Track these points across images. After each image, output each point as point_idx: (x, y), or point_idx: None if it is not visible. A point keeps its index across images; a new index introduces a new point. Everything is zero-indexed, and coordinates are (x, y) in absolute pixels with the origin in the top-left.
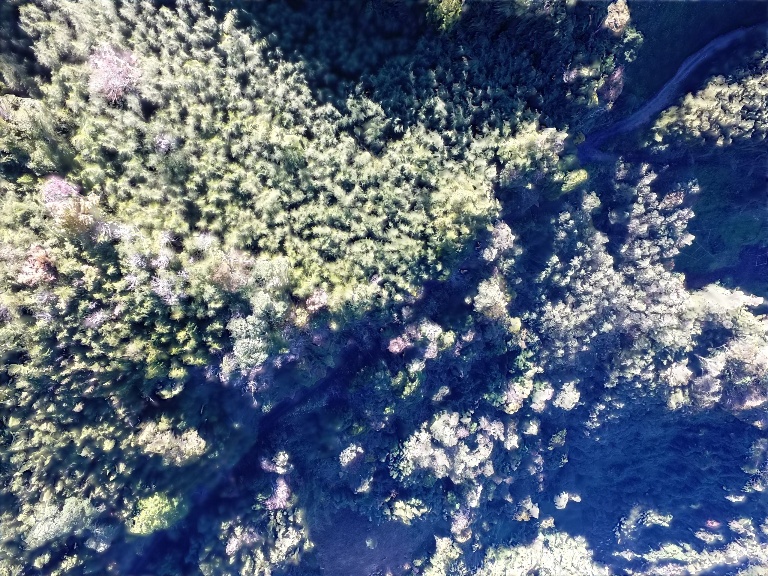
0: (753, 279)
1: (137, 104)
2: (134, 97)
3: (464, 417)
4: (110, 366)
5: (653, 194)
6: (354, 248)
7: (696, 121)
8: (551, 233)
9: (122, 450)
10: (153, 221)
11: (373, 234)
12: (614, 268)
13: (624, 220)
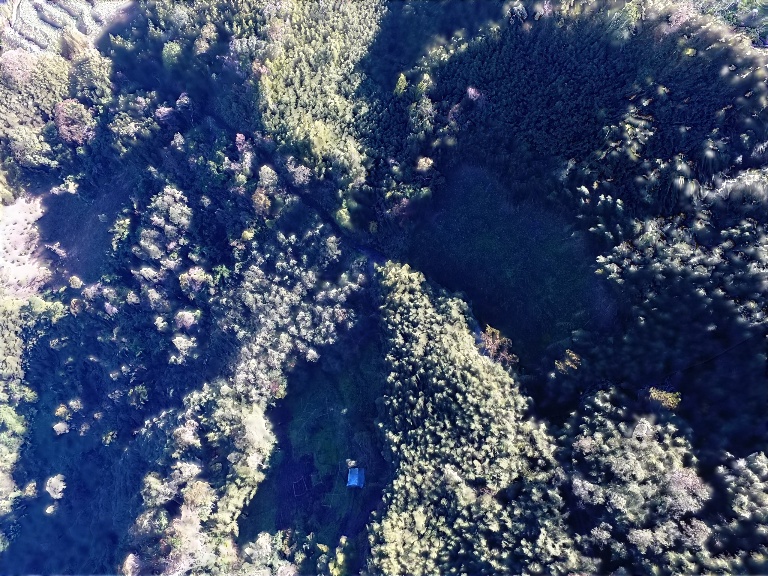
0: (280, 501)
1: (338, 5)
2: (340, 2)
3: (184, 240)
4: (240, 5)
5: (343, 294)
6: (291, 90)
7: (391, 273)
8: (311, 230)
9: (205, 23)
10: (295, 9)
11: (298, 98)
12: (290, 314)
13: (324, 288)
